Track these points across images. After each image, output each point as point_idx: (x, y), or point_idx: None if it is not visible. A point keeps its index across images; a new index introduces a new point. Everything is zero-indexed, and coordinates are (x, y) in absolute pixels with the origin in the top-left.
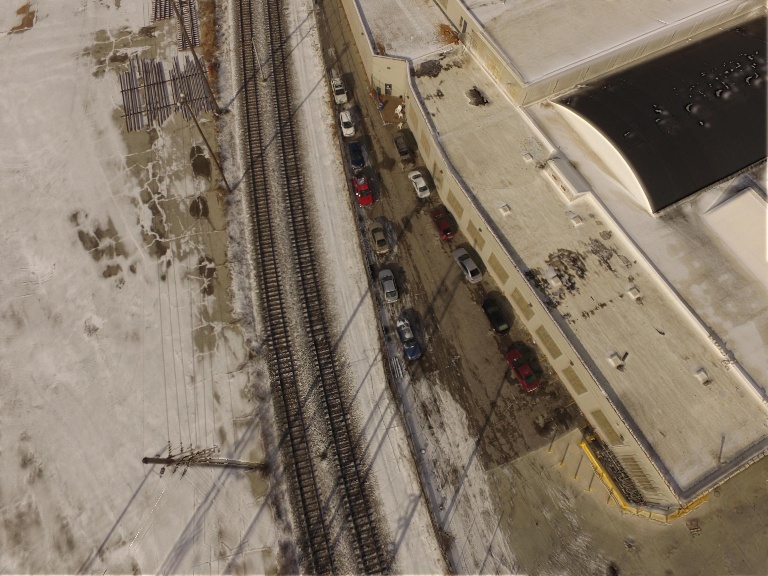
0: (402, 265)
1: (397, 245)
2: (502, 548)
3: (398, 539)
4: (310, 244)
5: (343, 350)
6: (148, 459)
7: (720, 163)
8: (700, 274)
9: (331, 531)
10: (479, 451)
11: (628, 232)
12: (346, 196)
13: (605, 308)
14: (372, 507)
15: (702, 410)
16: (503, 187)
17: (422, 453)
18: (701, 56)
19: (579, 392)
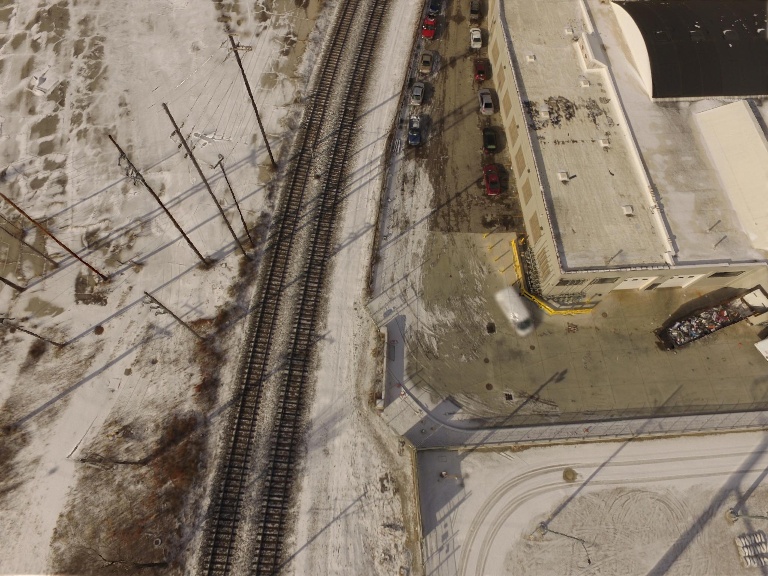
0: (435, 86)
1: (438, 72)
2: (417, 278)
3: (344, 244)
4: (372, 50)
5: (363, 122)
6: (198, 134)
7: (732, 82)
8: (668, 149)
9: (300, 221)
10: (431, 217)
11: (624, 103)
12: (415, 28)
13: (575, 143)
14: (336, 220)
15: (615, 229)
16: (538, 43)
17: (388, 201)
18: (763, 5)
19: (527, 202)
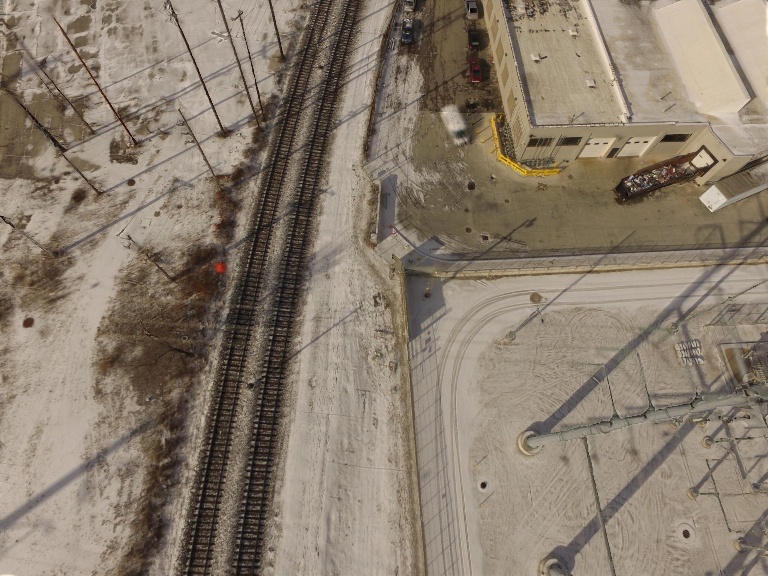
0: None
1: None
2: (407, 147)
3: (344, 120)
4: None
5: (362, 25)
6: (215, 33)
7: None
8: (629, 37)
9: (306, 102)
10: (421, 100)
11: (592, 1)
12: None
13: (547, 32)
14: (337, 101)
15: (579, 97)
16: None
17: (383, 86)
18: None
19: (505, 84)
